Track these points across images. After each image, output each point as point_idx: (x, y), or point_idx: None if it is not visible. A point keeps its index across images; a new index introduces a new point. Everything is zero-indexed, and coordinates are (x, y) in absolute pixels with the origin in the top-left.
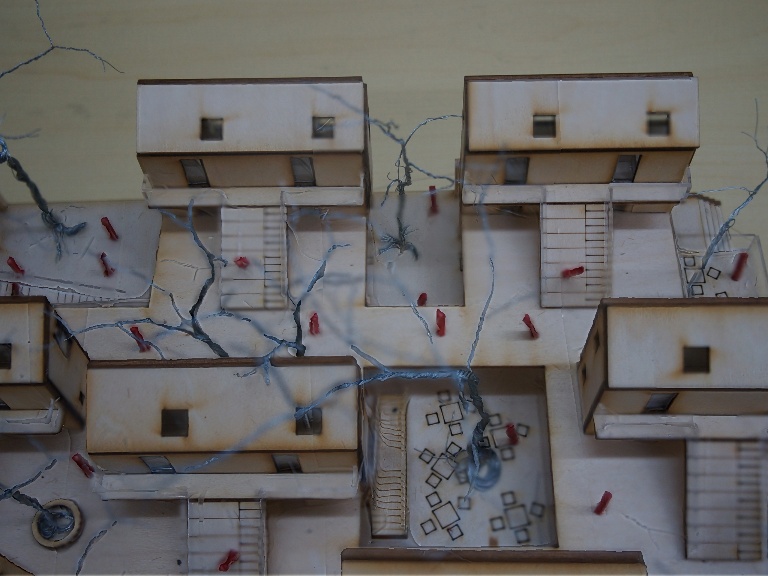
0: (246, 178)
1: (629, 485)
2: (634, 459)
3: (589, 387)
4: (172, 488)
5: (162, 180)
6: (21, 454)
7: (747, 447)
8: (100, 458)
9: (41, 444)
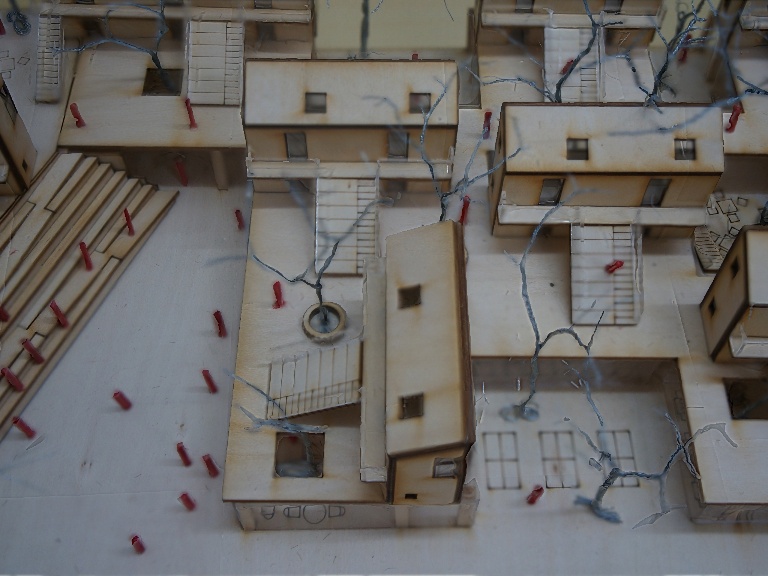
0: (565, 4)
1: None
2: None
3: None
4: (556, 216)
5: (495, 4)
6: (401, 209)
7: None
8: (513, 179)
9: (417, 201)
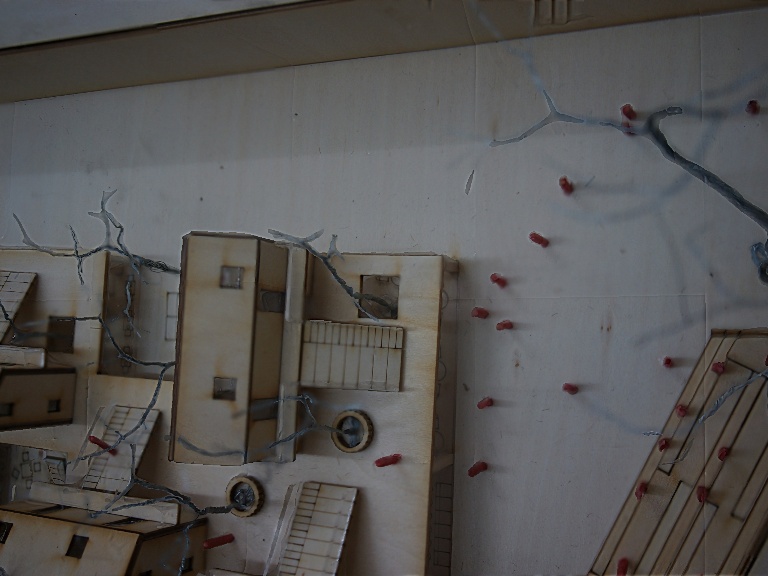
0: None
1: None
2: None
3: None
4: None
5: None
6: None
7: None
8: None
9: None
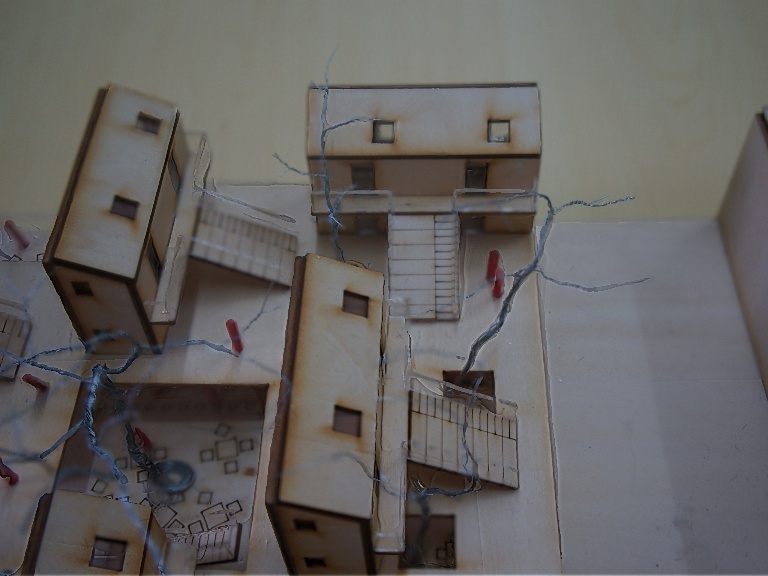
0: None
1: (218, 323)
2: (195, 317)
3: (121, 324)
4: None
5: None
6: None
7: (205, 216)
8: None
9: None
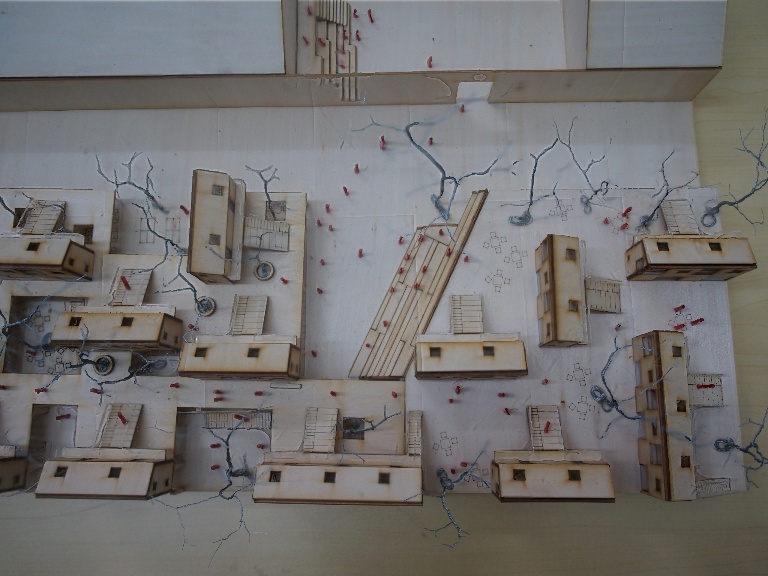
0: None
1: None
2: None
3: None
4: (147, 310)
5: None
6: None
7: None
8: None
9: None
